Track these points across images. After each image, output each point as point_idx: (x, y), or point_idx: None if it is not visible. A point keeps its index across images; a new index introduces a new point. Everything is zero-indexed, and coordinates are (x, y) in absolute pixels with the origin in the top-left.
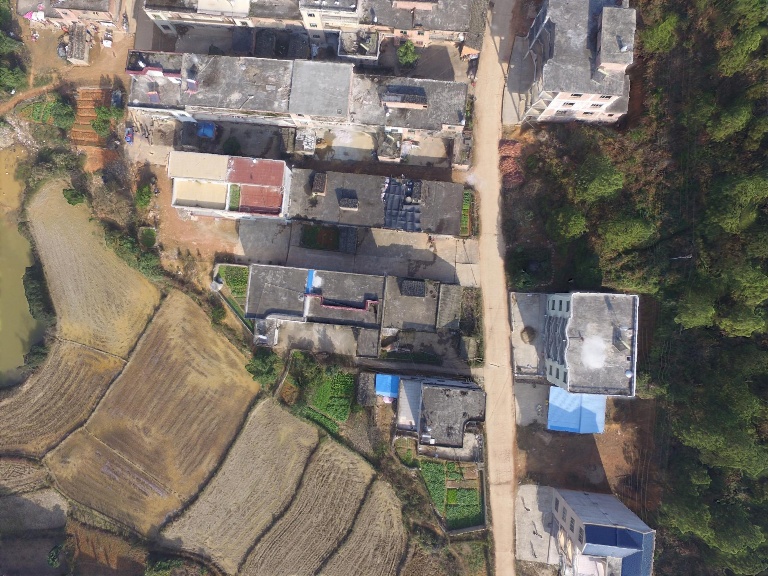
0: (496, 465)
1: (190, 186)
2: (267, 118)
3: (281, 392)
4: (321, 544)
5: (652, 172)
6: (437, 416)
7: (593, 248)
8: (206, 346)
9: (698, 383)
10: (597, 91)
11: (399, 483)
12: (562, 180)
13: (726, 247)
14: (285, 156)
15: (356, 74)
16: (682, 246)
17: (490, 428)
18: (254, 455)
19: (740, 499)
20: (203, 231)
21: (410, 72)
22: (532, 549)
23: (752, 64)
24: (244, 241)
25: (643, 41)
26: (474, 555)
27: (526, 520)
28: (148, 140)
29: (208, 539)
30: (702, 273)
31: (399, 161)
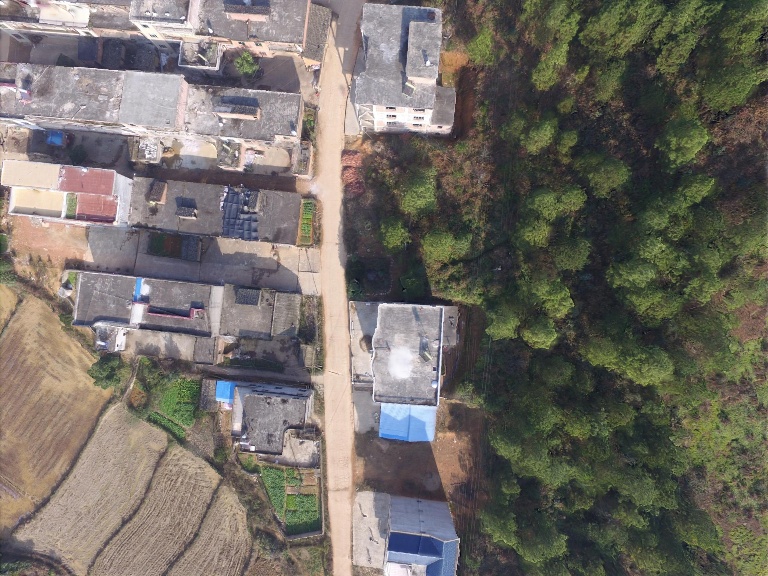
0: (334, 471)
1: (29, 194)
2: (104, 127)
3: (130, 397)
4: (168, 547)
5: (478, 184)
6: (258, 423)
7: (421, 258)
8: (60, 351)
9: (514, 393)
10: (408, 104)
11: (241, 488)
12: (394, 191)
13: (540, 259)
14: (132, 164)
15: (191, 84)
16: (500, 258)
17: (329, 435)
18: (105, 459)
19: (558, 508)
20: (54, 238)
21: (256, 82)
22: (368, 555)
23: (570, 78)
24: (93, 248)
25: (476, 54)
26: (312, 560)
27: (363, 526)
28: (3, 147)
29: (59, 541)
30: (521, 284)
31: (242, 170)
